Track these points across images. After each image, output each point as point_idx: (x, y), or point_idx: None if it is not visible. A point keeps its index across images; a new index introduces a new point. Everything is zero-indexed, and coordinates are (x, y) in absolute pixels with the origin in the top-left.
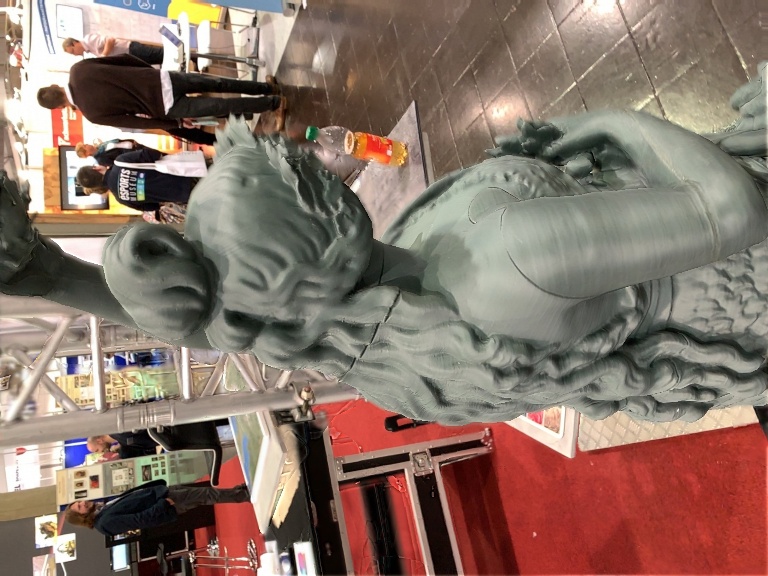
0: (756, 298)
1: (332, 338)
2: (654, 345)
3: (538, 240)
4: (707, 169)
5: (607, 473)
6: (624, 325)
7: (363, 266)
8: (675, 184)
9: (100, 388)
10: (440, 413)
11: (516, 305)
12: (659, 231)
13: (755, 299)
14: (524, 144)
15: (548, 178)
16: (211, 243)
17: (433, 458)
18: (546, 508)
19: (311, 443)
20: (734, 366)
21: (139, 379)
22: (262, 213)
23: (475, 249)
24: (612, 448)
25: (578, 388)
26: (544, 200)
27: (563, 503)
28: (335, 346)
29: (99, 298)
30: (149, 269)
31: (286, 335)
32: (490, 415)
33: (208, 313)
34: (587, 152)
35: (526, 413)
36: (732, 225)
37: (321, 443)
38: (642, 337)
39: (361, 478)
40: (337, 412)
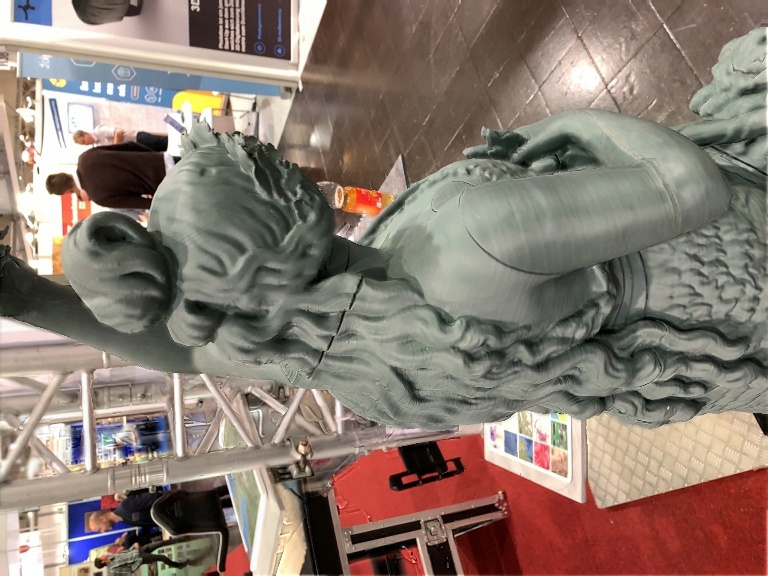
0: (732, 282)
1: (297, 330)
2: (632, 333)
3: (495, 215)
4: (661, 146)
5: (628, 531)
6: (597, 309)
7: (324, 252)
8: (633, 164)
9: (91, 447)
10: (416, 412)
11: (479, 282)
12: (617, 202)
13: (731, 283)
14: (490, 152)
15: (510, 171)
16: (170, 231)
17: (446, 525)
18: (568, 574)
19: (311, 501)
20: (718, 353)
21: (132, 439)
22: (220, 199)
23: (436, 231)
24: (631, 503)
25: (555, 376)
26: (502, 181)
27: (585, 567)
28: (301, 339)
29: (73, 319)
30: (105, 254)
31: (249, 325)
32: (469, 413)
33: (169, 304)
34: (552, 155)
35: (532, 459)
36: (690, 195)
37: (328, 513)
38: (620, 327)
39: (371, 550)
40: (337, 467)
